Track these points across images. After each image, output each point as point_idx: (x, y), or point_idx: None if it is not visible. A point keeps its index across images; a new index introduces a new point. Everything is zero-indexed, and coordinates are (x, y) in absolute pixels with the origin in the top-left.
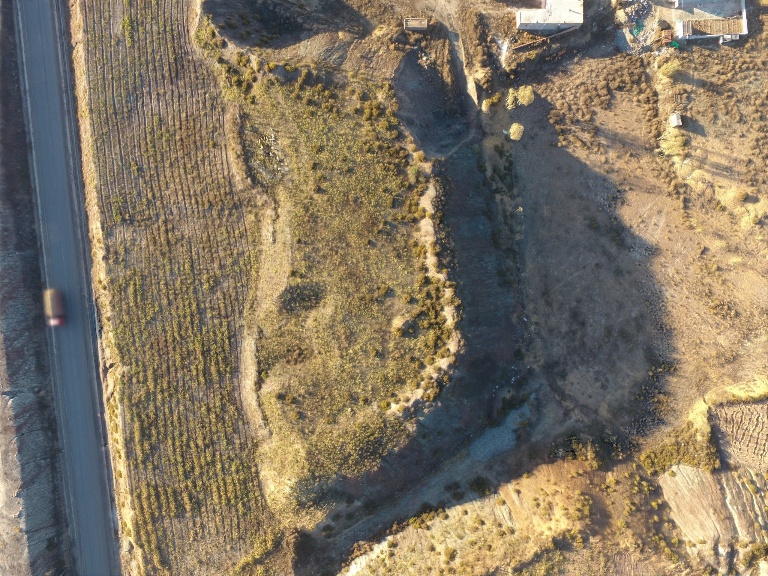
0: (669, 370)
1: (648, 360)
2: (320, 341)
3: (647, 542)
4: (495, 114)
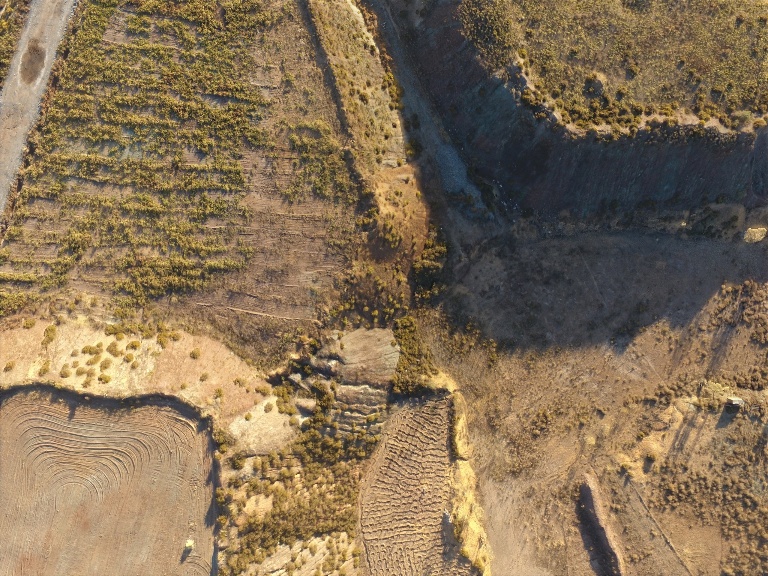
0: (491, 360)
1: (503, 341)
2: (591, 2)
3: (353, 289)
4: (767, 223)
